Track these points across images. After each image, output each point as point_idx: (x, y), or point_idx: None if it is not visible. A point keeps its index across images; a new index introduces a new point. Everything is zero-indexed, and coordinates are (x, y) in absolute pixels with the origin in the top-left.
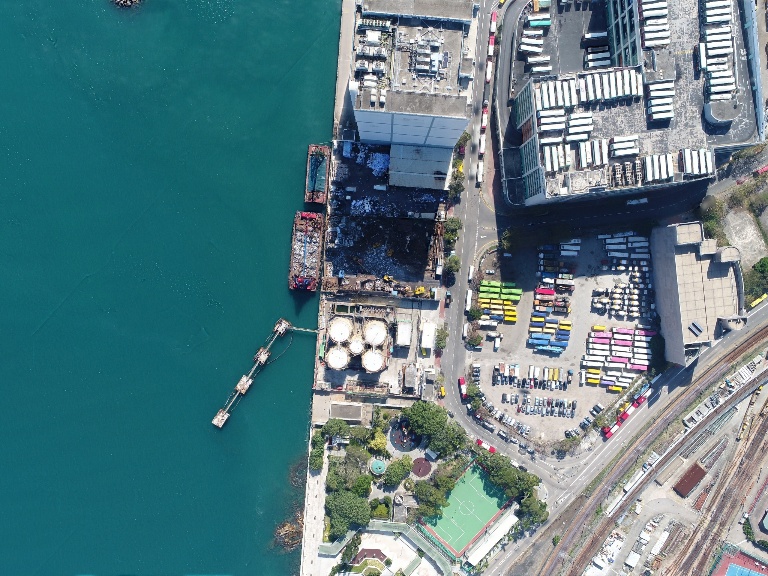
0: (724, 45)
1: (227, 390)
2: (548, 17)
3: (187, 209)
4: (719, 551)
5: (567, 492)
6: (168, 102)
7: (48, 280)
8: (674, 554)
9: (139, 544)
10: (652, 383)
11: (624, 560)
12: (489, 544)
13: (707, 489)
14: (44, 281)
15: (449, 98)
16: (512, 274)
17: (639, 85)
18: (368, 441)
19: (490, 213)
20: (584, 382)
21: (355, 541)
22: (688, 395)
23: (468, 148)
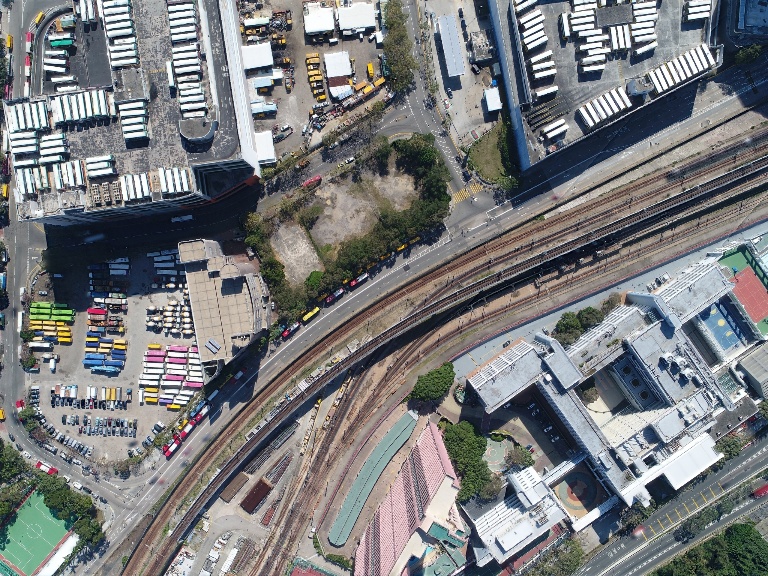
0: (191, 63)
1: None
2: (69, 37)
3: None
4: (290, 566)
5: (134, 512)
6: None
7: None
8: (245, 571)
9: None
10: (209, 400)
11: None
12: (52, 567)
13: (273, 504)
14: None
15: None
16: (66, 294)
17: (111, 105)
18: None
19: (40, 234)
20: (142, 401)
21: None
22: (249, 411)
23: None
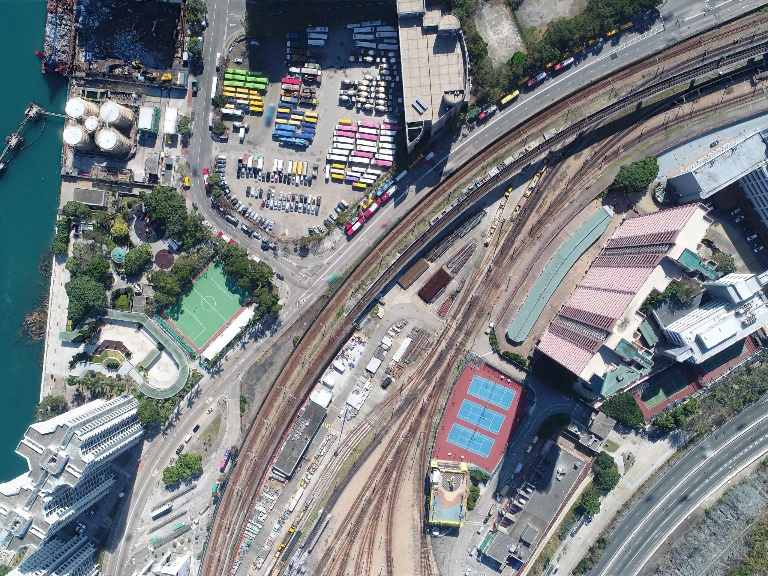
0: None
1: None
2: None
3: None
4: (464, 362)
5: (309, 292)
6: None
7: None
8: (417, 362)
9: None
10: (397, 180)
11: (365, 366)
12: (225, 338)
13: (452, 295)
14: None
15: None
16: (260, 64)
17: None
18: None
19: (240, 1)
20: (328, 177)
21: (92, 327)
22: (436, 196)
23: None
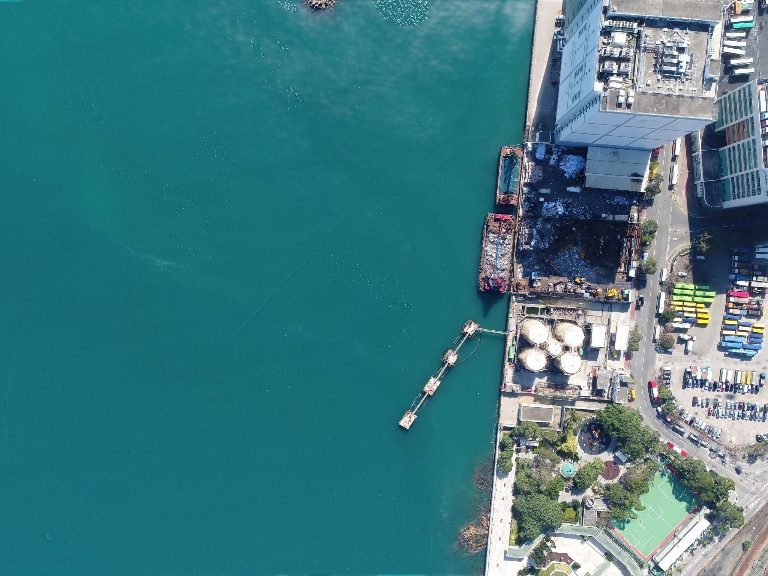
0: None
1: (414, 391)
2: (751, 19)
3: (390, 210)
4: None
5: (757, 497)
6: (359, 104)
7: (252, 280)
8: None
9: (337, 545)
10: None
11: None
12: (680, 549)
13: None
14: (248, 281)
15: (696, 99)
16: (704, 277)
17: None
18: (557, 444)
19: (683, 215)
20: None
21: (545, 544)
22: None
23: (661, 150)
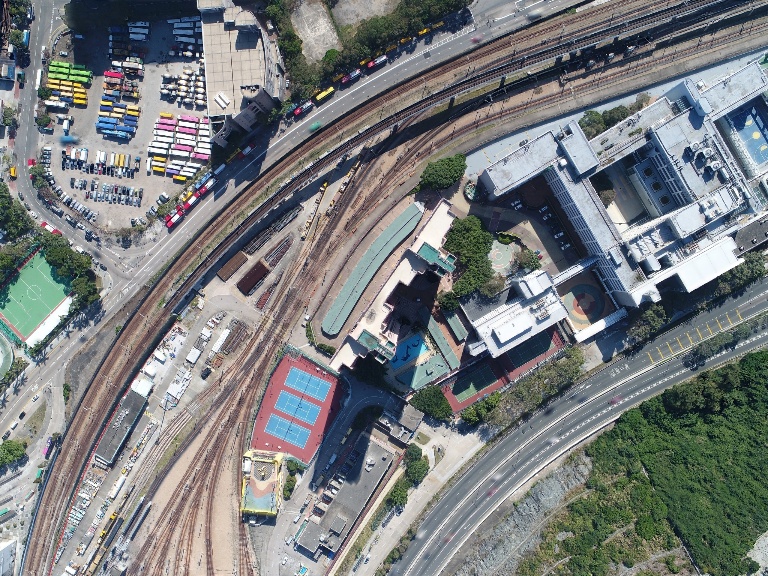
0: None
1: None
2: None
3: None
4: (281, 353)
5: (132, 282)
6: None
7: None
8: (235, 353)
9: None
10: (215, 174)
11: (186, 356)
12: (47, 327)
13: (270, 288)
14: None
15: None
16: (85, 57)
17: None
18: None
19: None
20: (149, 169)
21: None
22: (254, 190)
23: None
